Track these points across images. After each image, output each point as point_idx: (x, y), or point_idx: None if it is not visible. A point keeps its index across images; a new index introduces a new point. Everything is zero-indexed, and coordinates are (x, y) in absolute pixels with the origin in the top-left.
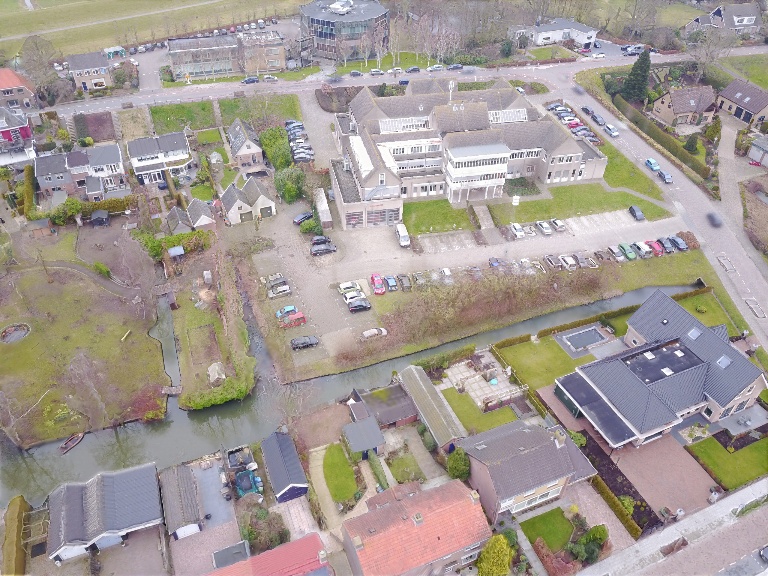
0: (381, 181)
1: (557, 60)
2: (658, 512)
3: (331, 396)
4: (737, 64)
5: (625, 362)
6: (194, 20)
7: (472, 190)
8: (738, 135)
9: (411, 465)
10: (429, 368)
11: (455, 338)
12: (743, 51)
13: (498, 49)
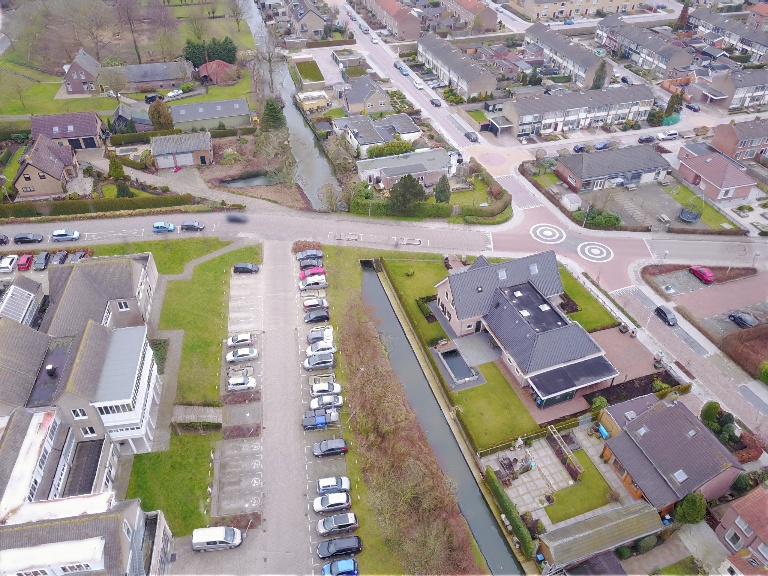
0: None
1: None
2: (658, 370)
3: None
4: None
5: None
6: None
7: None
8: None
9: (677, 572)
10: None
11: None
12: None
13: None
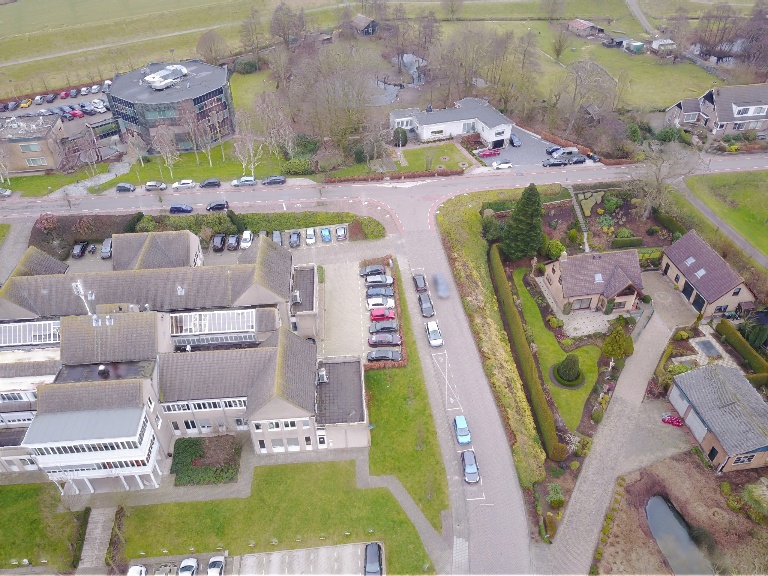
0: None
1: (432, 173)
2: None
3: None
4: (720, 187)
5: None
6: (38, 77)
7: None
8: (671, 341)
9: None
10: None
11: None
12: (736, 163)
13: (339, 156)
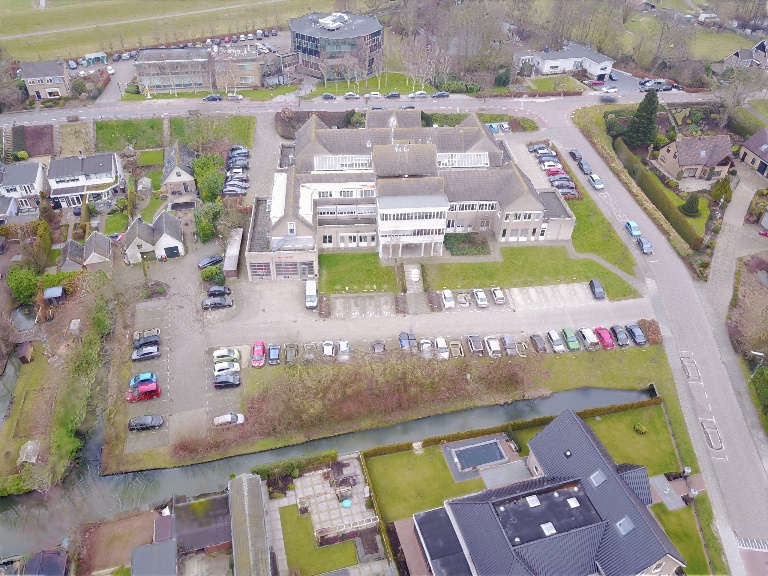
0: (291, 230)
1: (559, 93)
2: None
3: (170, 489)
4: None
5: (497, 508)
6: (194, 27)
7: (408, 244)
8: (755, 196)
9: None
10: (274, 475)
11: (325, 435)
12: None
13: (491, 77)
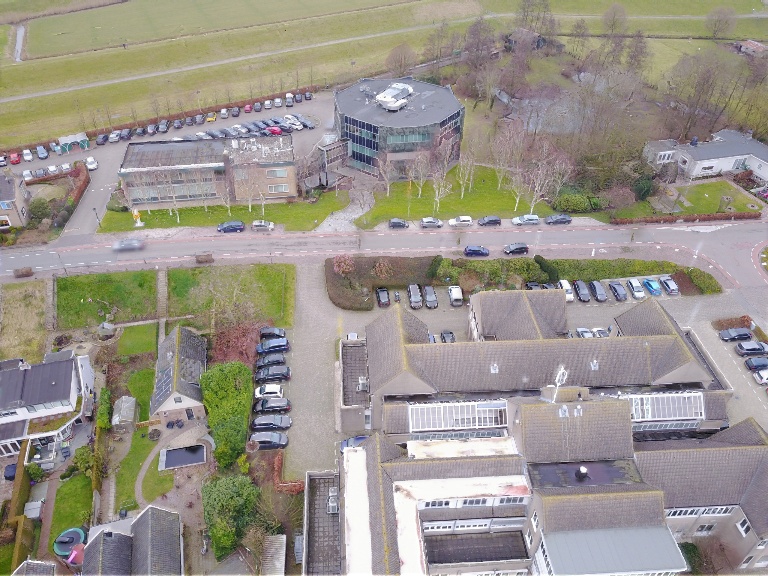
0: None
1: (729, 216)
2: None
3: None
4: None
5: None
6: (205, 86)
7: None
8: None
9: None
10: None
11: None
12: None
13: (633, 195)
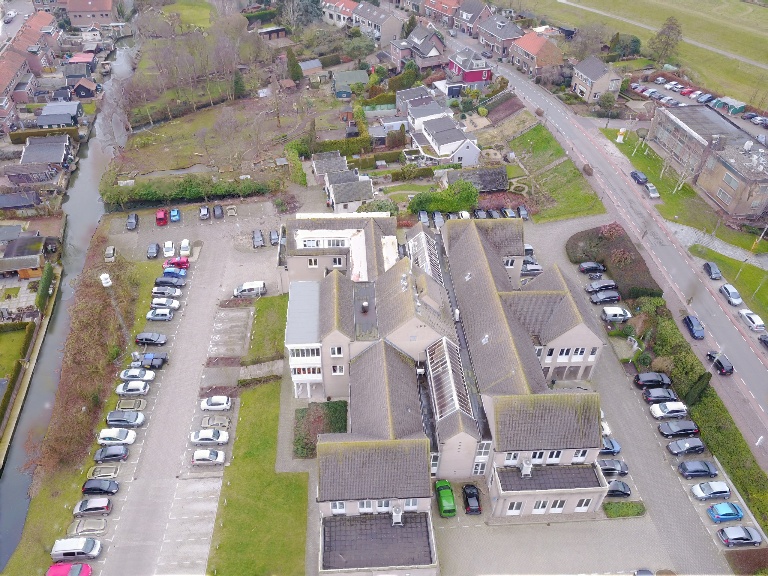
0: None
1: None
2: None
3: None
4: None
5: None
6: None
7: None
8: None
9: None
10: None
11: None
12: None
13: None
